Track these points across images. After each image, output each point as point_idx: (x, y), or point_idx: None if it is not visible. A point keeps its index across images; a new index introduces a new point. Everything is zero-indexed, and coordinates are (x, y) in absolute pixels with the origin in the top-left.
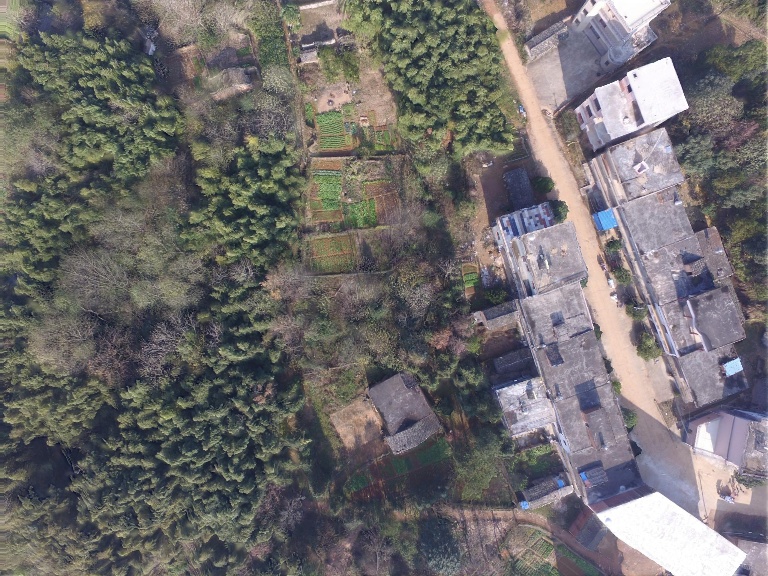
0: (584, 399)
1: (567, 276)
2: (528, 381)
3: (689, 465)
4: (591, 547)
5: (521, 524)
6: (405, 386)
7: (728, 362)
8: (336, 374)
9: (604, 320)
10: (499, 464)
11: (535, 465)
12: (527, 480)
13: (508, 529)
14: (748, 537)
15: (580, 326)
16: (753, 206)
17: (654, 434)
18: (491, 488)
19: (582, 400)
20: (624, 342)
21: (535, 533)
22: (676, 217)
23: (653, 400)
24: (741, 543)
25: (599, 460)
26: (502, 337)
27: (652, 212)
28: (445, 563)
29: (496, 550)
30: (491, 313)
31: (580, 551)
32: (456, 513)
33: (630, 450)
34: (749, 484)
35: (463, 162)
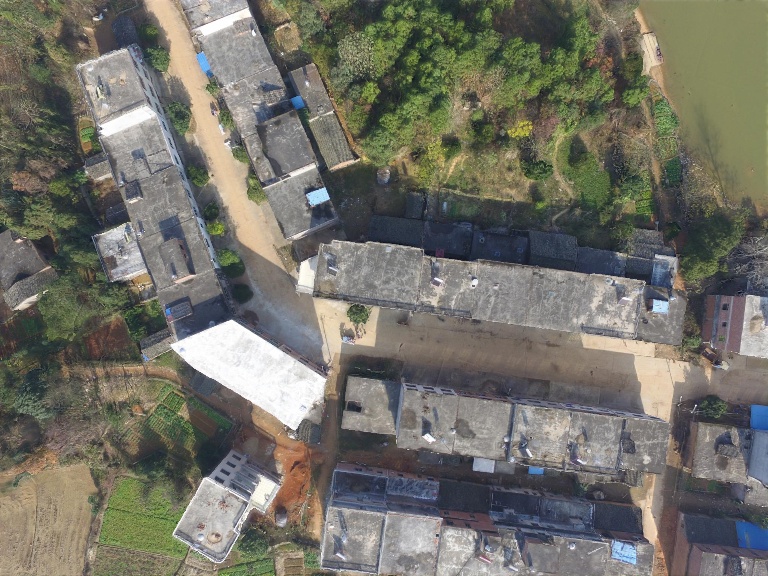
0: (169, 235)
1: (127, 105)
2: (125, 225)
3: (311, 309)
4: (202, 391)
5: (150, 378)
6: None
7: (312, 191)
8: None
9: (219, 167)
10: None
11: (160, 317)
12: (153, 333)
13: (139, 384)
14: (362, 375)
15: (162, 162)
16: (328, 32)
17: (274, 280)
18: (121, 344)
19: (167, 236)
20: (240, 189)
21: (165, 387)
22: (255, 49)
23: (272, 246)
24: (351, 380)
25: (187, 296)
26: None
27: (230, 44)
28: (23, 402)
29: (126, 405)
30: (92, 160)
31: (211, 403)
32: (88, 371)
33: (218, 285)
34: (356, 320)
35: (75, 17)
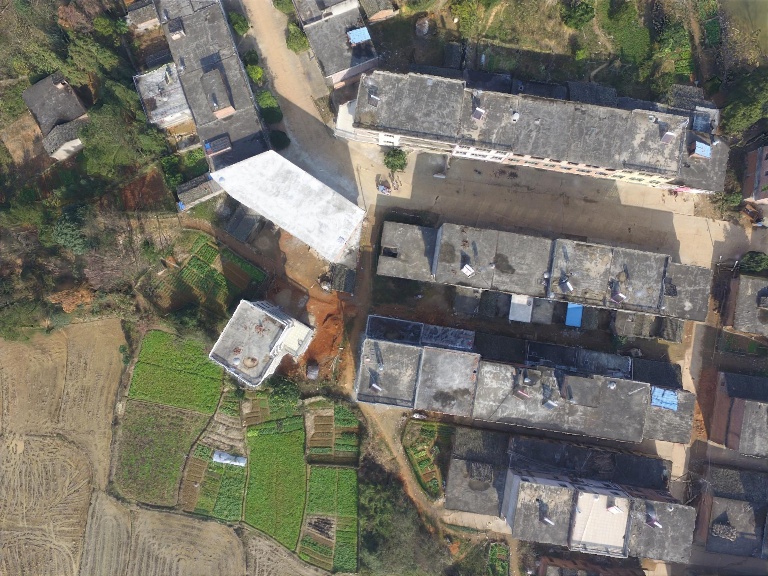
0: None
1: None
2: (166, 67)
3: (347, 160)
4: (238, 235)
5: (184, 229)
6: (53, 83)
7: (353, 30)
8: (2, 89)
9: (259, 19)
10: (161, 169)
11: (196, 168)
12: None
13: (173, 236)
14: None
15: (205, 1)
16: None
17: (311, 130)
18: (156, 196)
19: None
20: (279, 40)
21: (199, 238)
22: None
23: (309, 97)
24: (387, 225)
25: (226, 132)
26: (160, 42)
27: None
28: (62, 229)
29: (160, 256)
30: (134, 6)
31: (244, 254)
32: (123, 223)
33: (257, 122)
34: (393, 165)
35: None
